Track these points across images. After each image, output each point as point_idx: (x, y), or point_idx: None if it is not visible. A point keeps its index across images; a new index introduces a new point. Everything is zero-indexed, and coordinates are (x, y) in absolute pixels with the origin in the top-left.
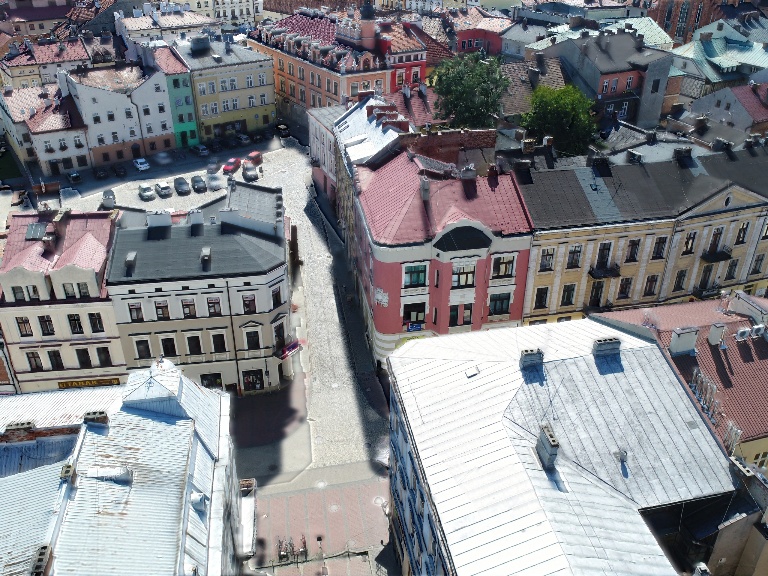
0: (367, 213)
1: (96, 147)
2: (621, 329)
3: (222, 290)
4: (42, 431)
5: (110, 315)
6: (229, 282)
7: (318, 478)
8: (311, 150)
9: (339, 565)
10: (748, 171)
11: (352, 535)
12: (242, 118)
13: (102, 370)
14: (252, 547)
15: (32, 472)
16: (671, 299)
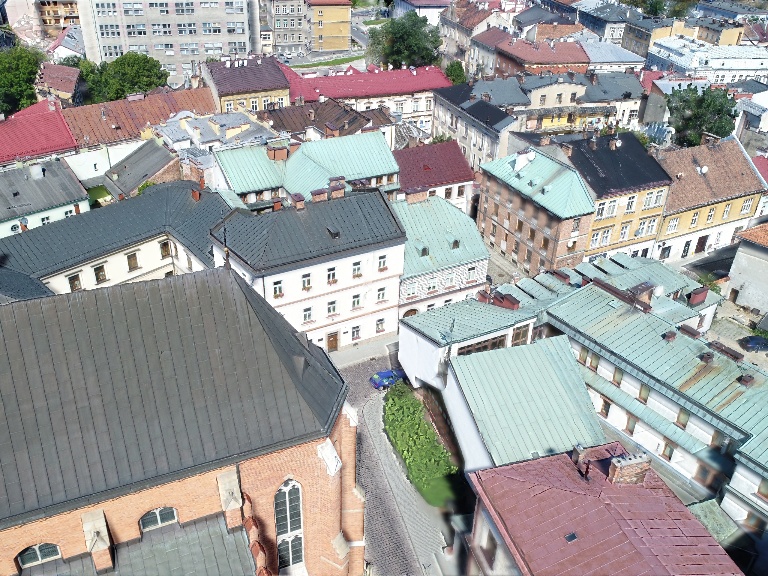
0: None
1: None
2: None
3: None
4: None
5: None
6: None
7: None
8: None
9: None
10: None
11: None
12: None
13: None
14: None
15: None
16: None
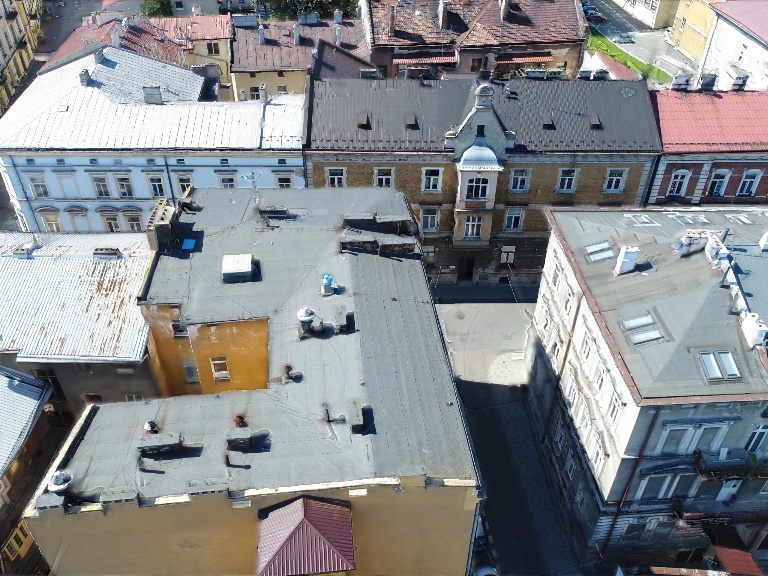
0: None
1: None
2: (75, 60)
3: None
4: None
5: None
6: None
7: None
8: None
9: None
10: None
11: None
12: None
13: None
14: None
15: None
16: None
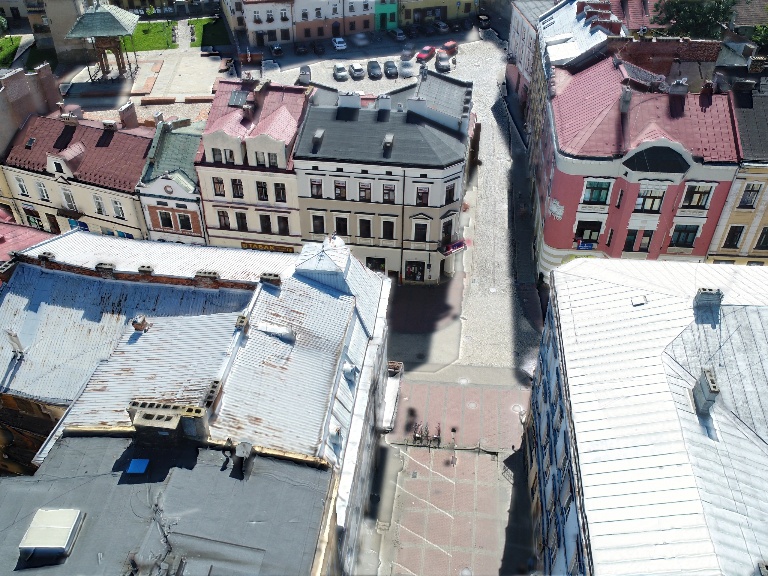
0: (557, 119)
1: (300, 22)
2: None
3: (399, 179)
4: (225, 282)
5: (293, 187)
6: (406, 172)
7: (462, 375)
8: (509, 45)
9: (468, 458)
10: None
11: (485, 434)
12: (444, 4)
13: (280, 237)
14: (391, 423)
15: (213, 316)
16: None
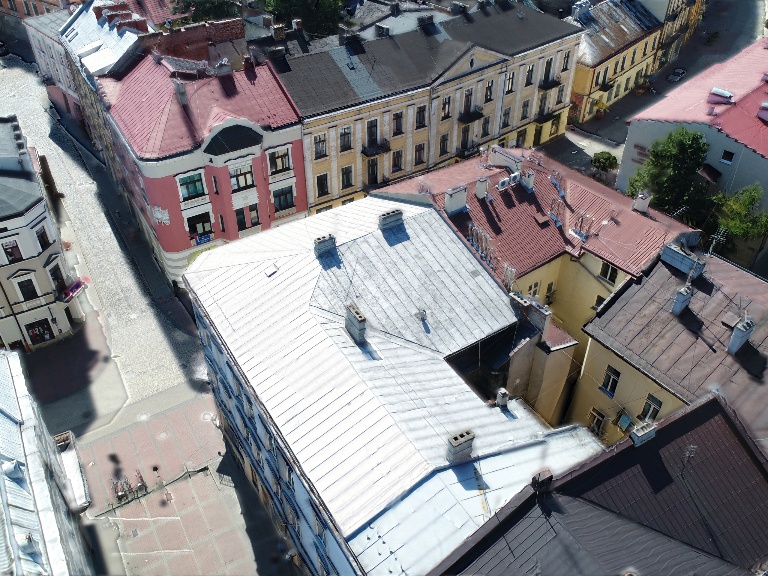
0: (123, 128)
1: None
2: (401, 200)
3: None
4: None
5: None
6: None
7: (139, 412)
8: (39, 67)
9: (182, 487)
10: (485, 31)
11: (188, 456)
12: None
13: None
14: (86, 497)
15: None
16: (439, 164)
